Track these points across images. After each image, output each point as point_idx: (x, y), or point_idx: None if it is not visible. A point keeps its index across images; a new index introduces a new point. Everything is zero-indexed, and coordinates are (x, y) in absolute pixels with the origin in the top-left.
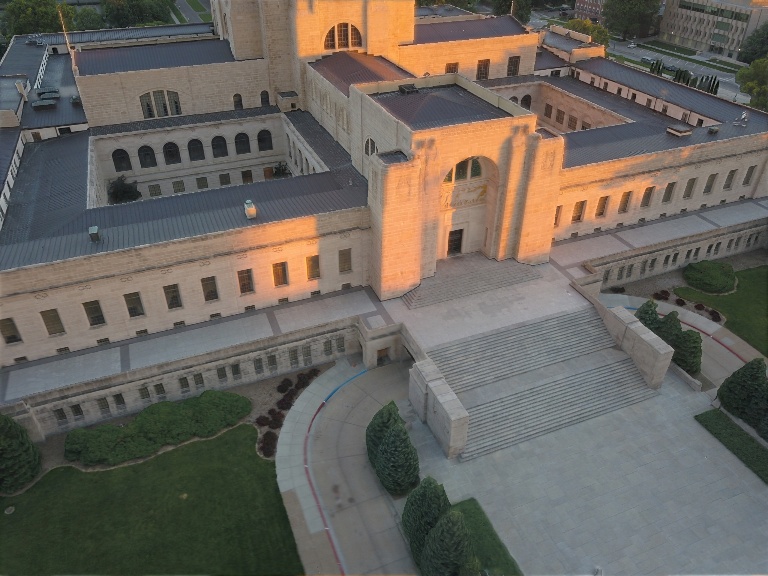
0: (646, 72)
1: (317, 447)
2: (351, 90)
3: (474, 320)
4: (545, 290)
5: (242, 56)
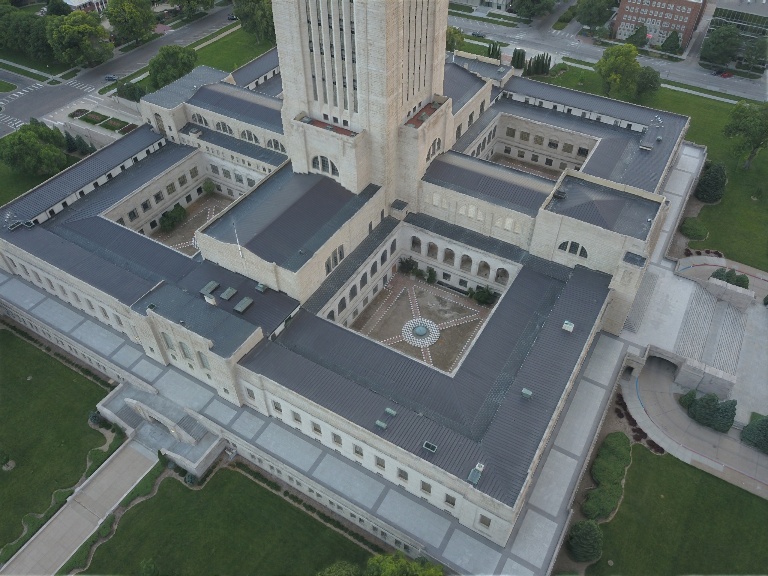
0: (561, 87)
1: (672, 433)
2: (544, 213)
3: (668, 322)
4: (670, 284)
5: (360, 190)
